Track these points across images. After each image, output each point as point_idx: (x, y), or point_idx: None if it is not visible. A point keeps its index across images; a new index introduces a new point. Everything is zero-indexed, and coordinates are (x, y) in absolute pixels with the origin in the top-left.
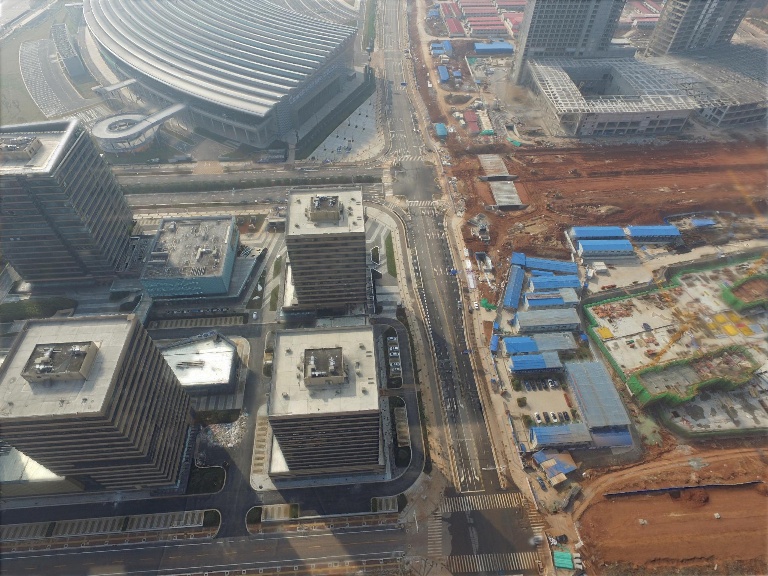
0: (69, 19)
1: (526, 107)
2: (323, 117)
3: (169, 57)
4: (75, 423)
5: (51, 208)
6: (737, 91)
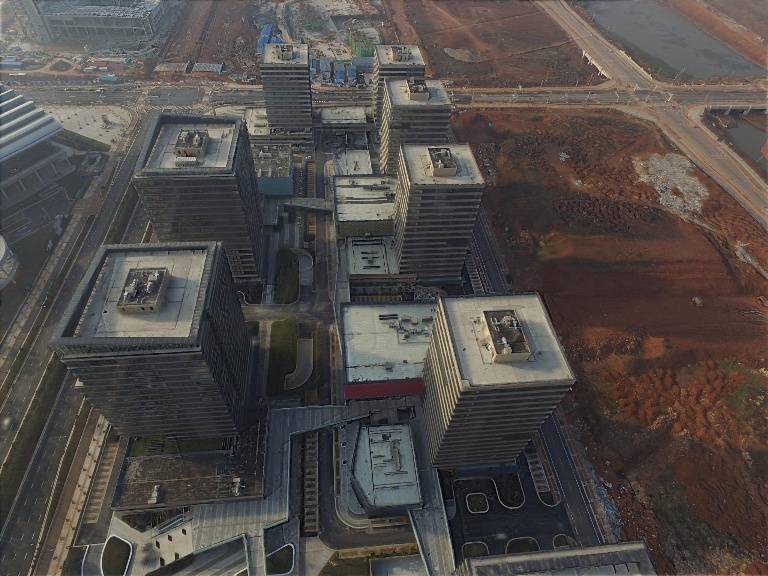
0: None
1: (97, 44)
2: None
3: None
4: None
5: None
6: None
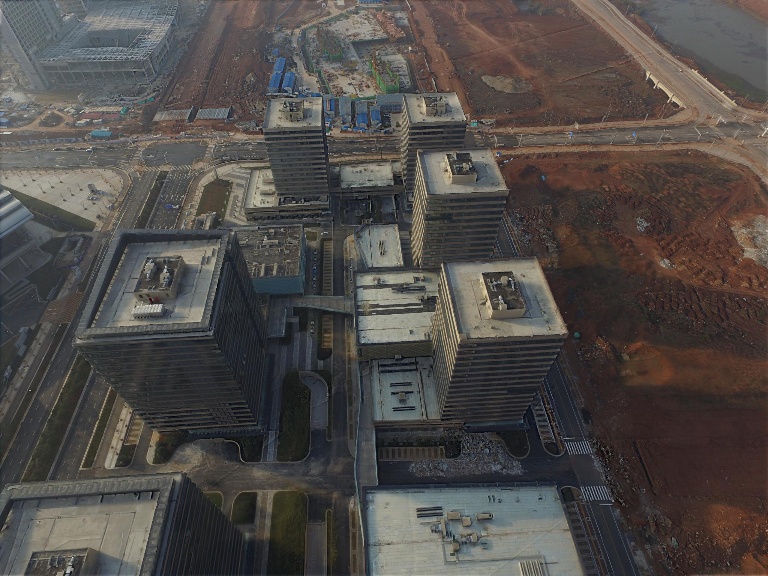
0: None
1: (94, 90)
2: None
3: None
4: None
5: (242, 279)
6: (162, 2)
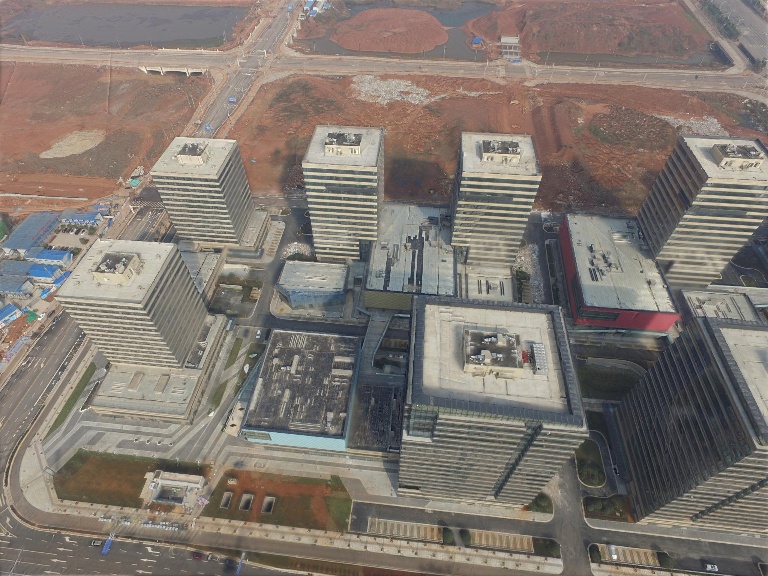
0: None
1: None
2: None
3: None
4: None
5: None
6: None
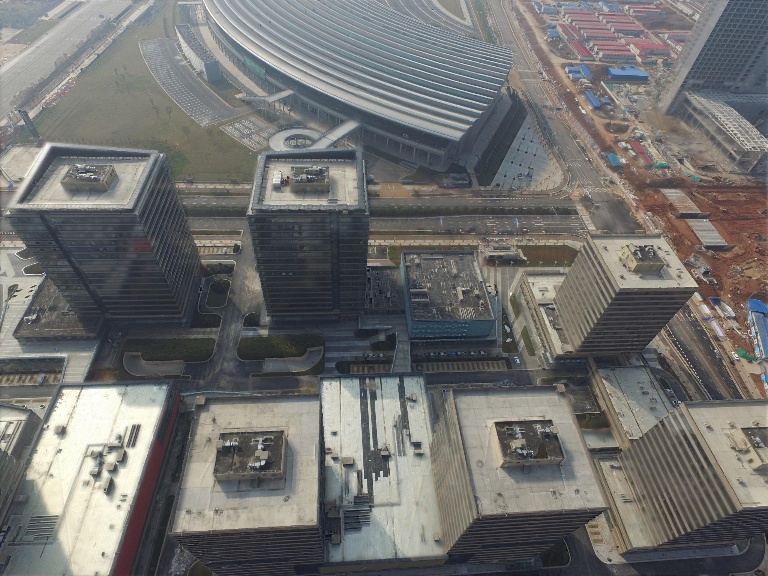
0: (179, 18)
1: (686, 139)
2: (489, 140)
3: (333, 70)
4: (564, 516)
5: (345, 245)
6: None
